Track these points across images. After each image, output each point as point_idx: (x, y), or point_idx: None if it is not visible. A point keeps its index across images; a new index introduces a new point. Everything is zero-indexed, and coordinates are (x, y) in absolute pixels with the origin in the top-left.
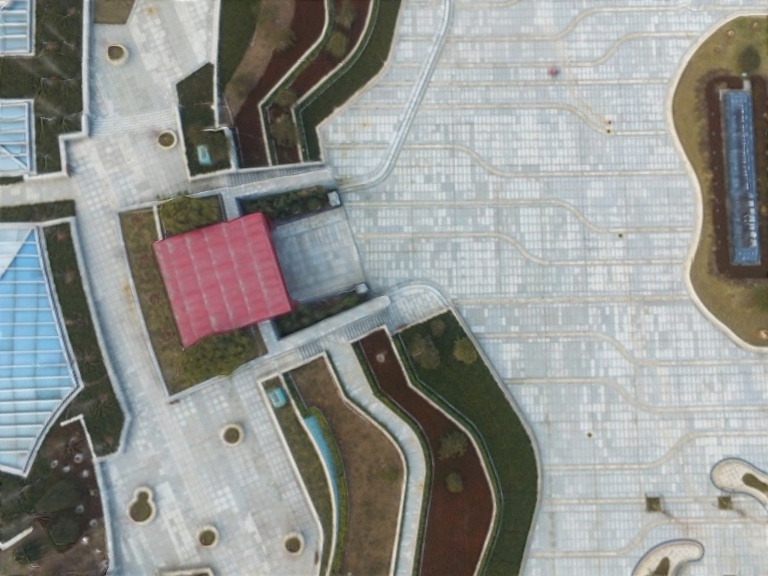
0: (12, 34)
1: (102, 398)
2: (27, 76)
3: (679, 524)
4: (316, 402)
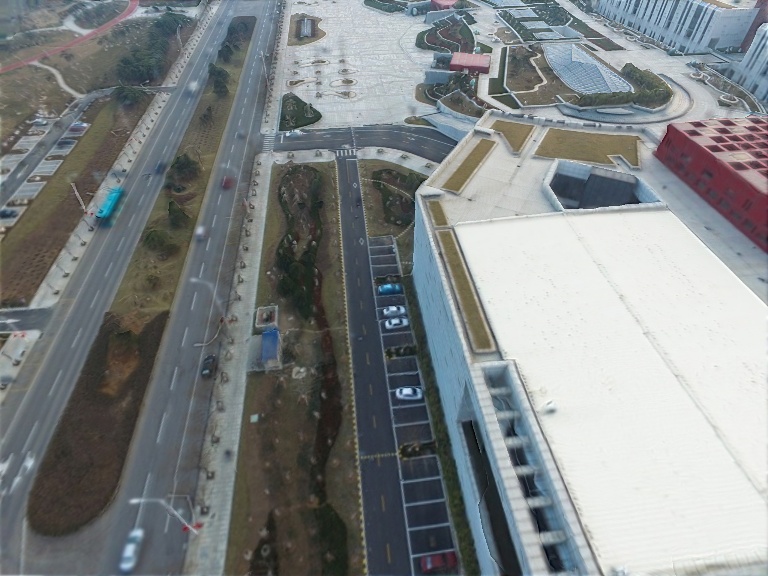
0: None
1: None
2: None
3: None
4: (422, 0)
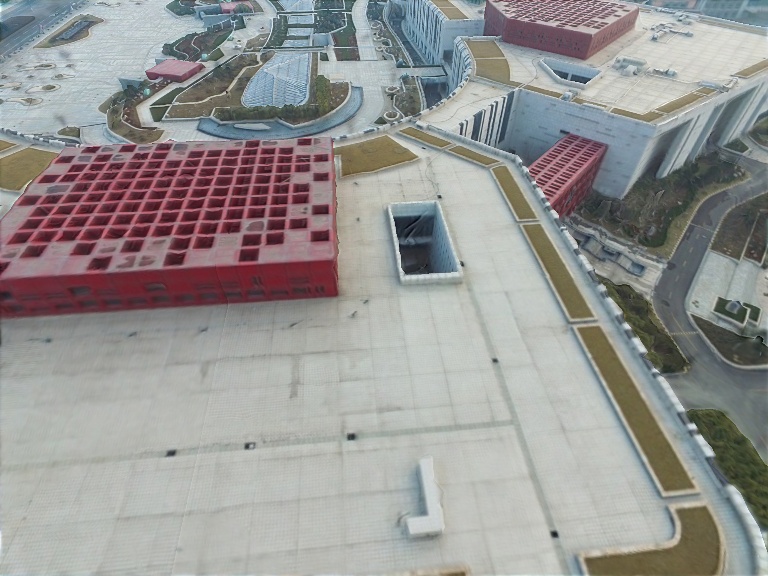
0: (295, 30)
1: None
2: (290, 25)
3: None
4: None
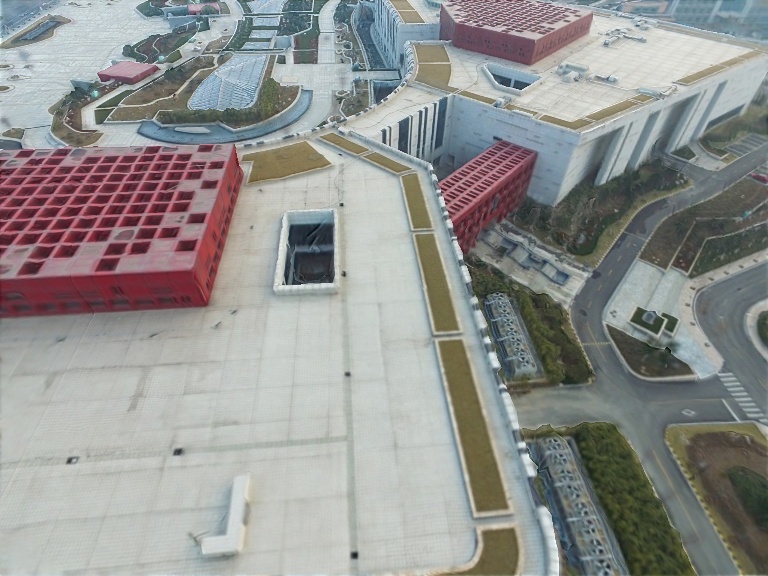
0: (258, 32)
1: (241, 1)
2: (254, 27)
3: (104, 3)
4: None
